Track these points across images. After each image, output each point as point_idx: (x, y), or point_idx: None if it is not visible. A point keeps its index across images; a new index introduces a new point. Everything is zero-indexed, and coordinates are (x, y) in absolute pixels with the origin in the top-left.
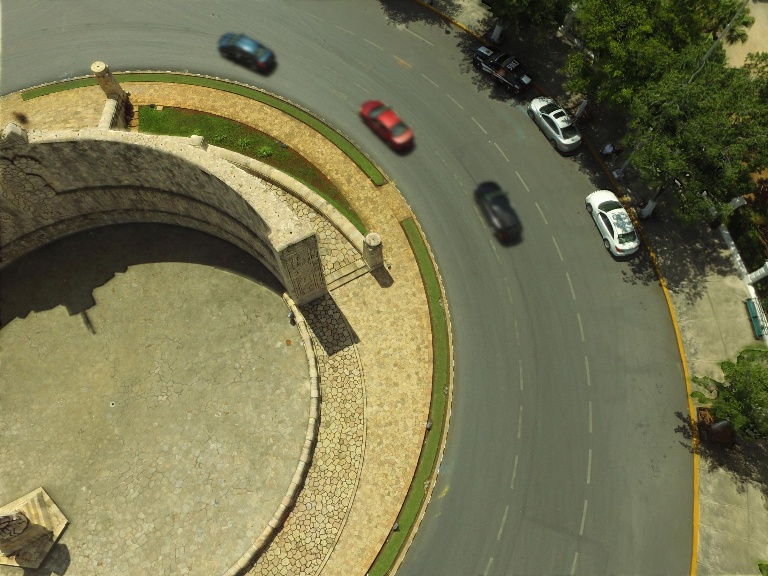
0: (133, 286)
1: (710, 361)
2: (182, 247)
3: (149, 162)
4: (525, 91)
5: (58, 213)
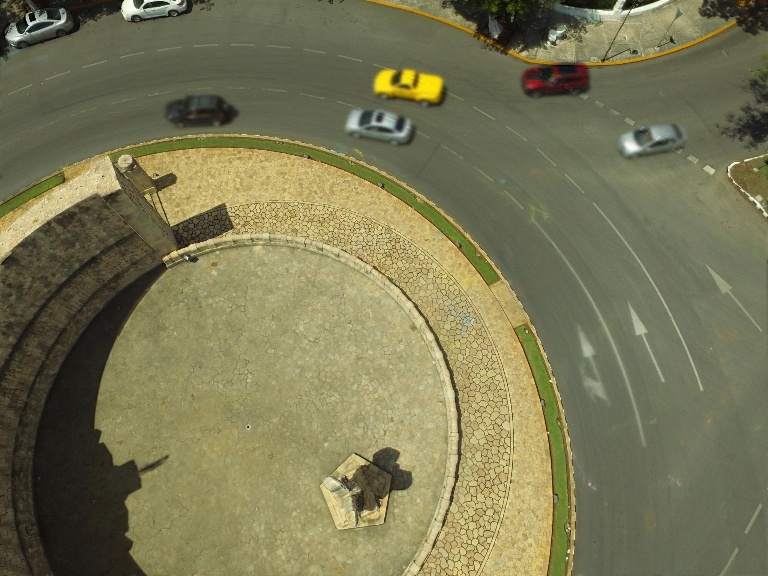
0: (120, 421)
1: None
2: (85, 371)
3: None
4: None
5: (2, 497)
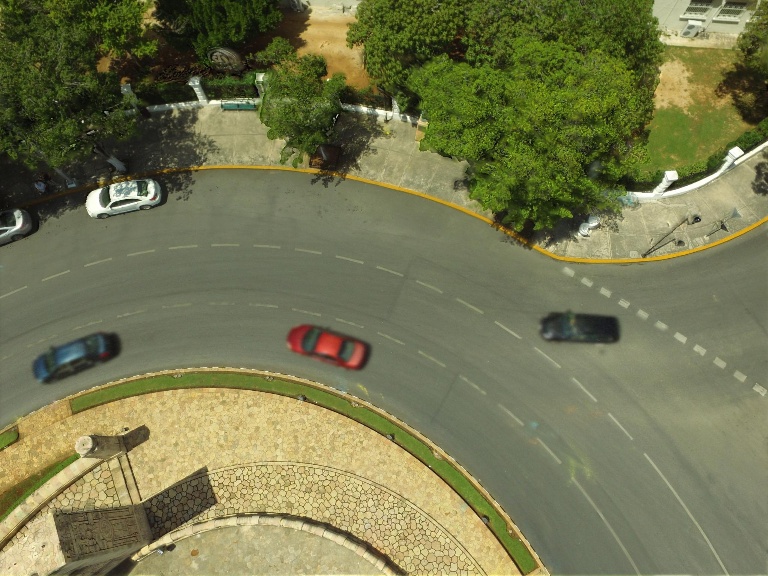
0: None
1: (271, 148)
2: None
3: None
4: None
5: None
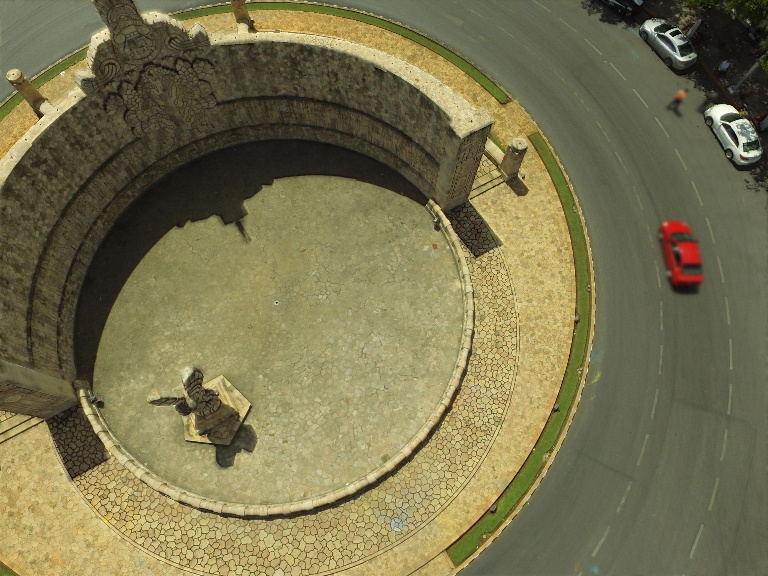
0: (281, 197)
1: None
2: (323, 161)
3: (316, 66)
4: (636, 13)
5: (212, 126)
